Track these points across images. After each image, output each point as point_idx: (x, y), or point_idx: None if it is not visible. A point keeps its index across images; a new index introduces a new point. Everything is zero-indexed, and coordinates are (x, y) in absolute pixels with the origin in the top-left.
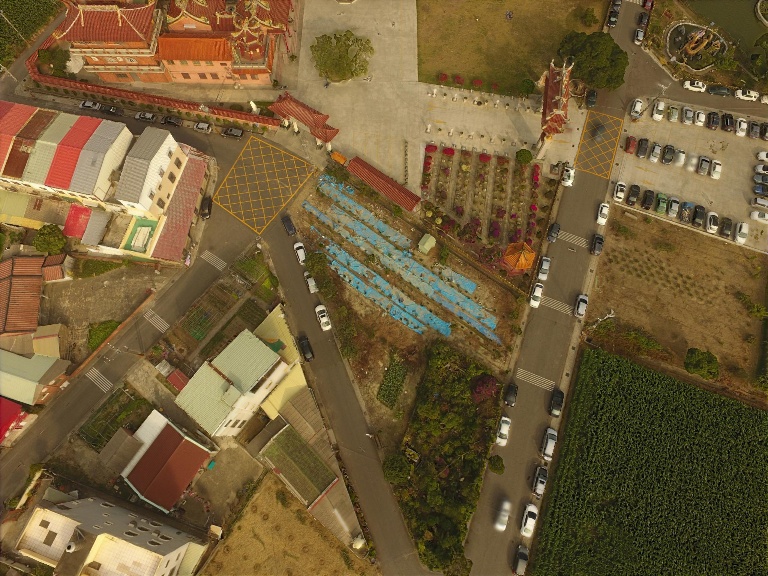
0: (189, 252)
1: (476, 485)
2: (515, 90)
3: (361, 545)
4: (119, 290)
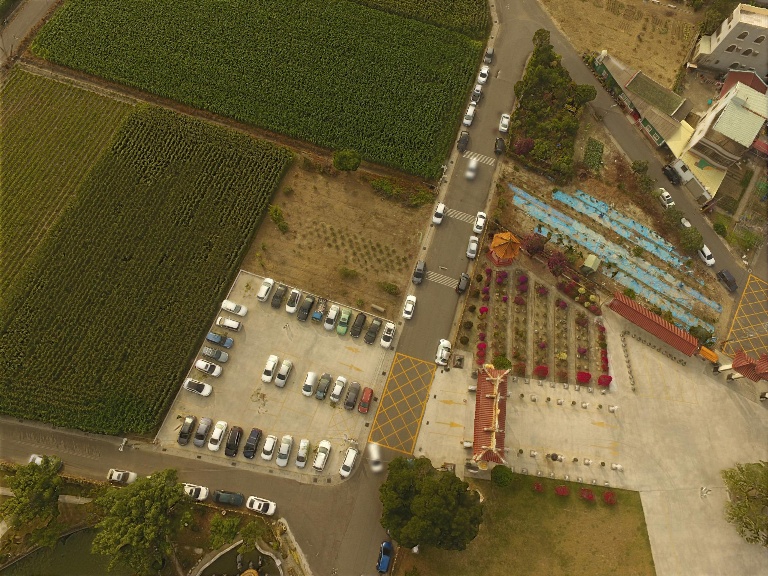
0: None
1: None
2: None
3: None
4: None
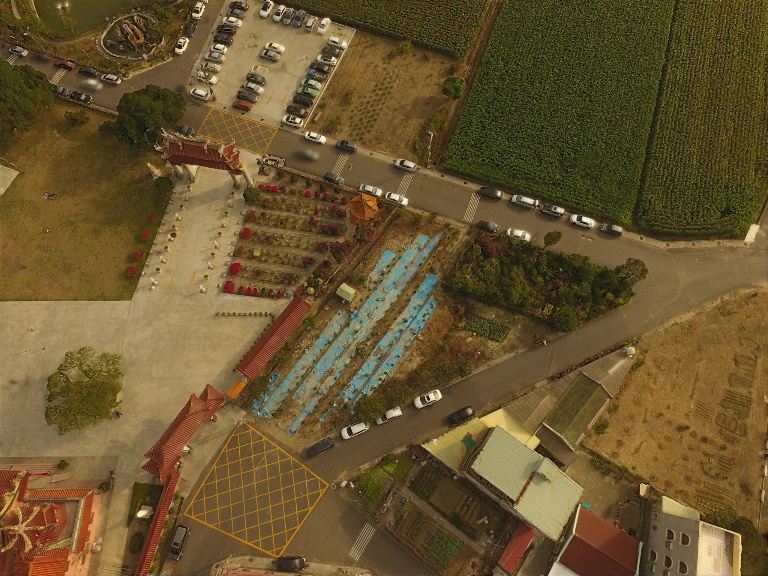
0: (355, 575)
1: None
2: (160, 199)
3: None
4: None
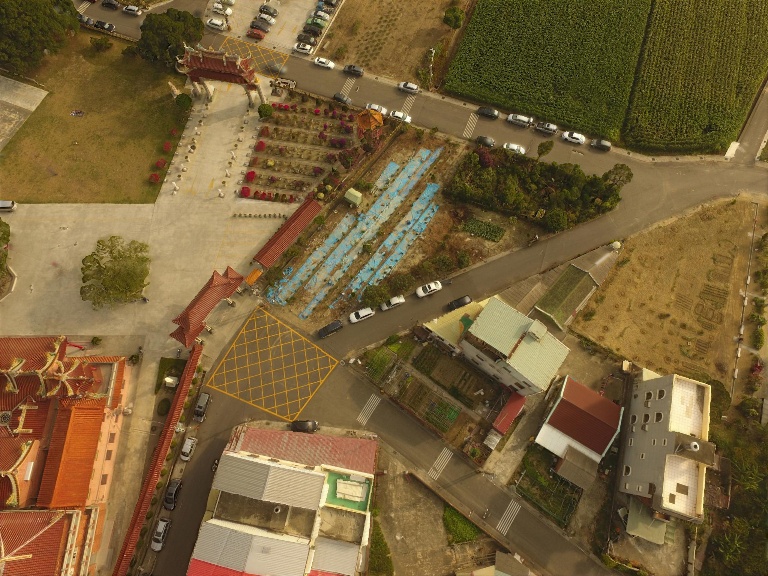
0: None
1: None
2: (180, 116)
3: None
4: (407, 518)
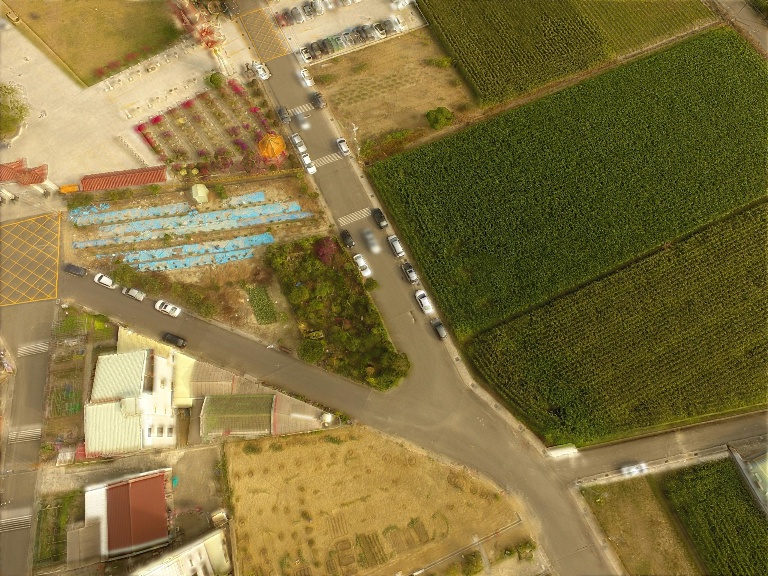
0: (2, 361)
1: (371, 310)
2: (173, 40)
3: (329, 418)
4: None
